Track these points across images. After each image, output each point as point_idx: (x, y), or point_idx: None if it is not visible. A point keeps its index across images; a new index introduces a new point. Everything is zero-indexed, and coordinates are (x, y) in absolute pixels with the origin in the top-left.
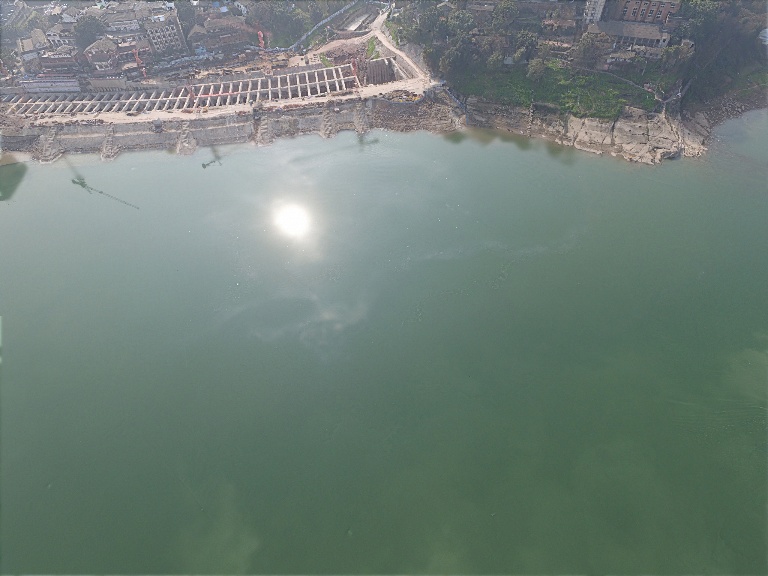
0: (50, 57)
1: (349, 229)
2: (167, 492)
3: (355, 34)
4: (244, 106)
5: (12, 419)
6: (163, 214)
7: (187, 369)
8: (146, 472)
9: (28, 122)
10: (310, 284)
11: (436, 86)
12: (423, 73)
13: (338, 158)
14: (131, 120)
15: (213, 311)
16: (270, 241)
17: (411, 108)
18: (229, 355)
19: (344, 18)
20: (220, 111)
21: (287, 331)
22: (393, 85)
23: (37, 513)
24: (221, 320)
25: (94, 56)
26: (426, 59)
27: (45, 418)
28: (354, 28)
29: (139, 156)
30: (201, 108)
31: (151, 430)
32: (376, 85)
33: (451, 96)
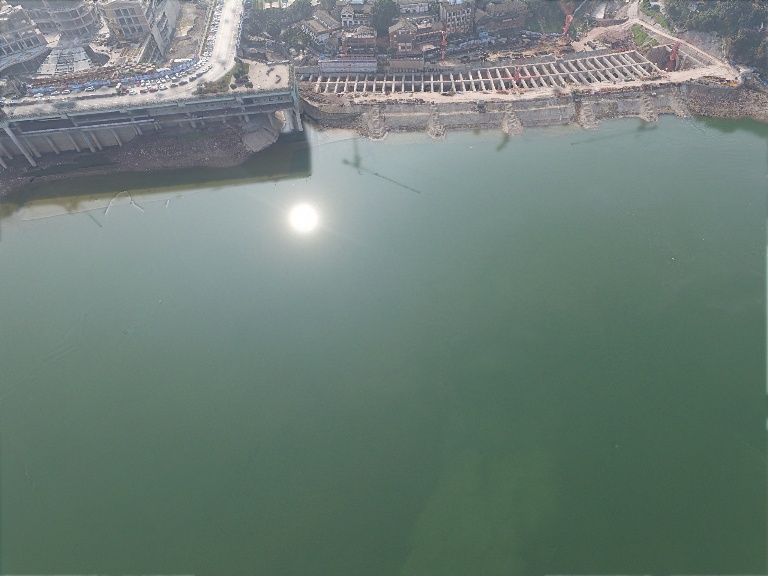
0: (353, 37)
1: (745, 209)
2: (741, 456)
3: (613, 22)
4: (558, 88)
5: (533, 382)
6: (537, 191)
7: (683, 339)
8: (714, 435)
9: (346, 100)
10: (748, 260)
11: (747, 72)
12: (719, 60)
13: (675, 141)
14: (451, 100)
15: (663, 284)
16: (669, 219)
17: (732, 93)
18: (723, 326)
19: (592, 6)
20: (537, 93)
21: (767, 304)
22: (697, 71)
23: (623, 472)
24: (672, 293)
25: (400, 37)
26: (734, 45)
27: (567, 382)
28: (602, 16)
29: (467, 135)
30: (514, 90)
31: (683, 396)
32: (679, 71)
33: (762, 83)
